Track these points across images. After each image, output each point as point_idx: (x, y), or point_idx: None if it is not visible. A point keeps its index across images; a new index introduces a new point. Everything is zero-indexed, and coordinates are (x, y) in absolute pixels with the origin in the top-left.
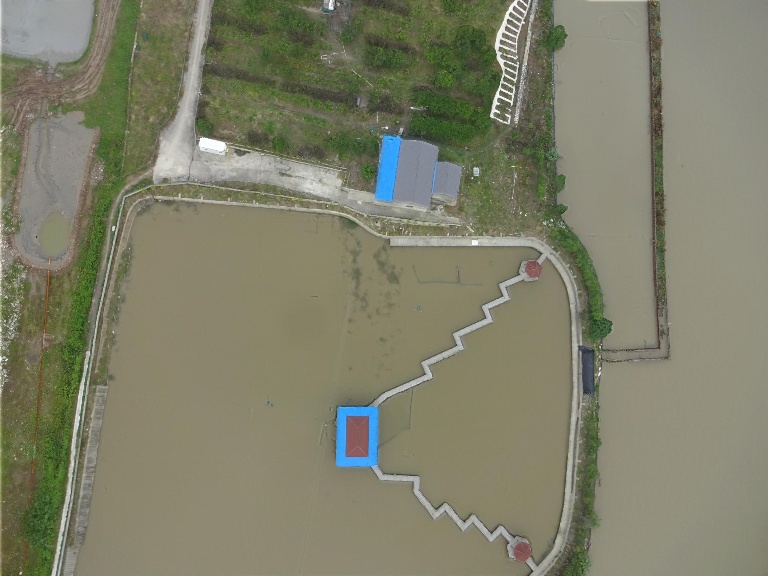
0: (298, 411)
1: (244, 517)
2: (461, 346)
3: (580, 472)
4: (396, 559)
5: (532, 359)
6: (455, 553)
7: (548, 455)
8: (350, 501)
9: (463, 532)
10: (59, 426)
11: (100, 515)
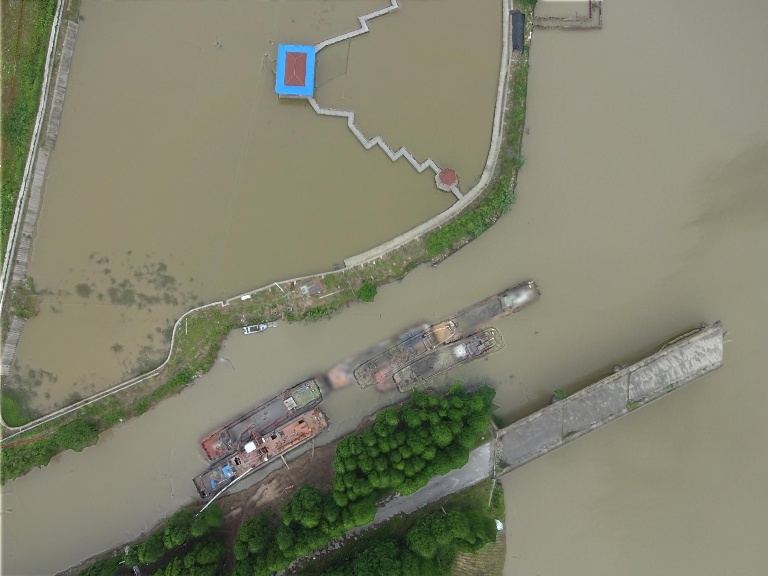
0: (244, 52)
1: (192, 131)
2: (396, 6)
3: (507, 118)
4: (330, 181)
5: (465, 22)
6: (386, 181)
7: (477, 104)
8: (289, 131)
9: (394, 164)
10: (35, 50)
11: (69, 130)
